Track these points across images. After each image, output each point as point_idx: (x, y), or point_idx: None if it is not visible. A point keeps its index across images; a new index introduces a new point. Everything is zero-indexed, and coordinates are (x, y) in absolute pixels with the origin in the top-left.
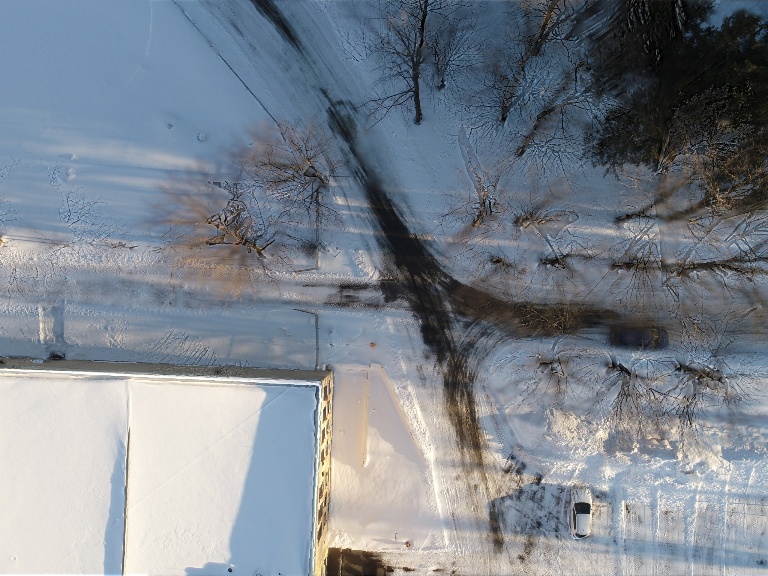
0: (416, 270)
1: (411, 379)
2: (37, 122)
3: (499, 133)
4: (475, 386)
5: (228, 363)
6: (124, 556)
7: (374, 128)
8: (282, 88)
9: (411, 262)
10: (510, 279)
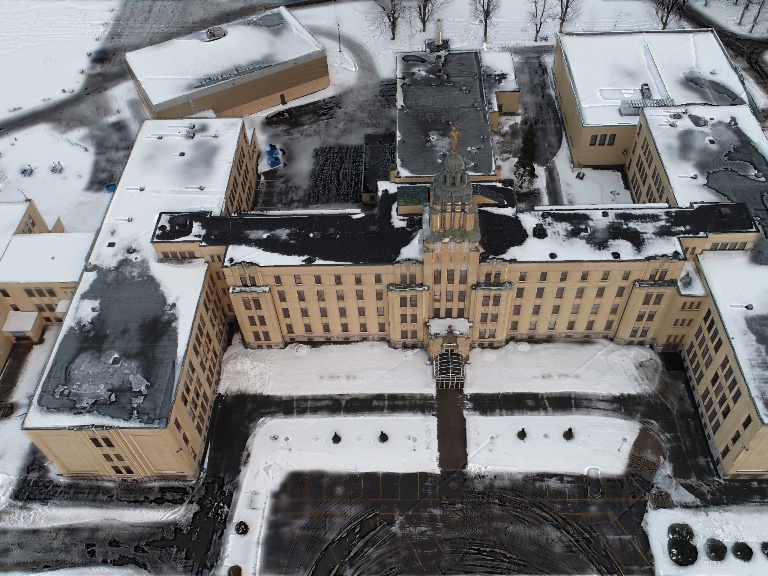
0: (722, 37)
1: (734, 61)
2: None
3: (736, 6)
4: (760, 62)
5: None
6: (658, 70)
7: (691, 7)
8: (654, 2)
9: (719, 35)
10: (759, 36)
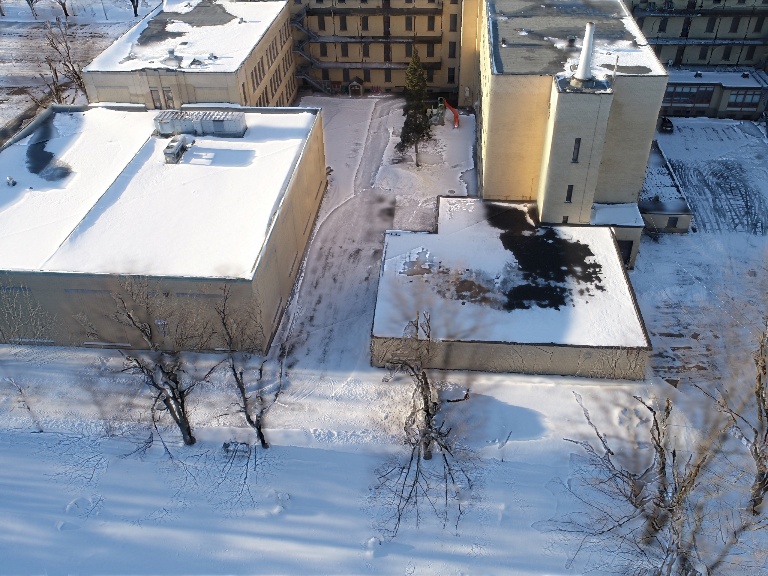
0: None
1: None
2: (90, 571)
3: None
4: None
5: (2, 345)
6: None
7: None
8: None
9: None
10: None
